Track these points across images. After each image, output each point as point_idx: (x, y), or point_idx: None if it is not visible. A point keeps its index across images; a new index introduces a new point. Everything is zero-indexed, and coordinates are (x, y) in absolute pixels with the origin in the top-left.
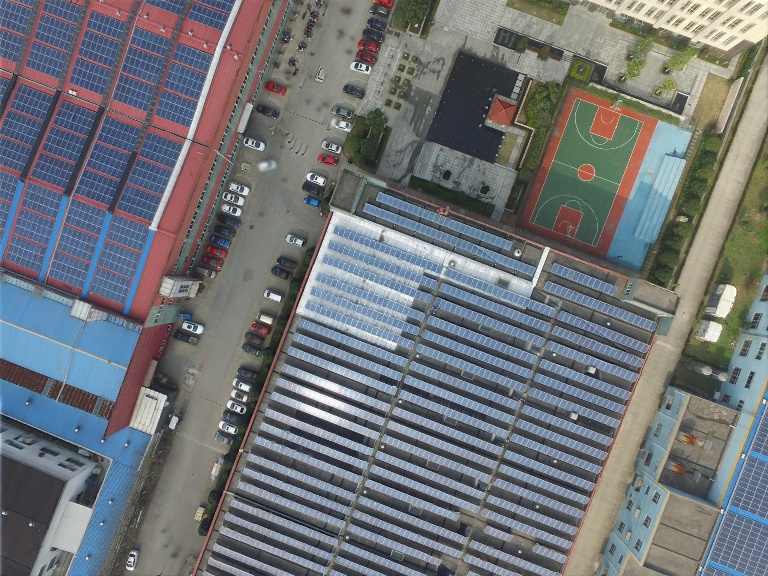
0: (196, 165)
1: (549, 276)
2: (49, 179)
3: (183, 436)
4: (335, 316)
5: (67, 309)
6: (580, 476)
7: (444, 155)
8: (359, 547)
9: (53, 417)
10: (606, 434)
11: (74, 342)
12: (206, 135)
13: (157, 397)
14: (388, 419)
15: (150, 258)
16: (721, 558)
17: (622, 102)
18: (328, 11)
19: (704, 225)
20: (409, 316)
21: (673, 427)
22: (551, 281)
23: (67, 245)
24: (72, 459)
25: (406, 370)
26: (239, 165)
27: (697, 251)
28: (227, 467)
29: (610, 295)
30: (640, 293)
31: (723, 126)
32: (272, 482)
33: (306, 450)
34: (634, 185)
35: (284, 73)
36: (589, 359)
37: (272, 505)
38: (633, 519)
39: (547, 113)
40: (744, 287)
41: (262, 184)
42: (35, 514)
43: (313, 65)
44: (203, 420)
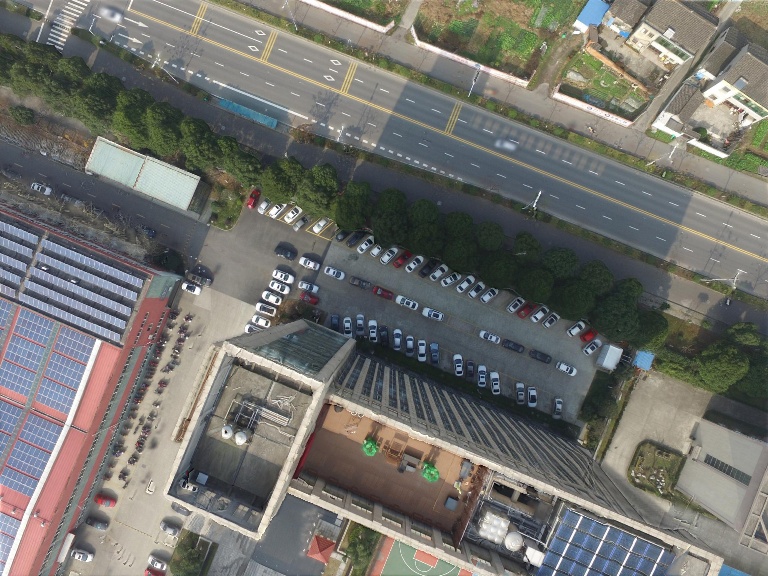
0: None
1: None
2: None
3: None
4: None
5: None
6: None
7: None
8: None
9: None
10: None
11: None
12: None
13: None
14: None
15: None
16: None
17: None
18: (161, 424)
19: None
20: None
21: None
22: None
23: None
24: None
25: None
26: (67, 574)
27: None
28: None
29: None
30: None
31: None
32: None
33: None
34: None
35: (115, 484)
36: None
37: None
38: None
39: (358, 568)
40: None
41: None
42: None
43: (144, 477)
44: None
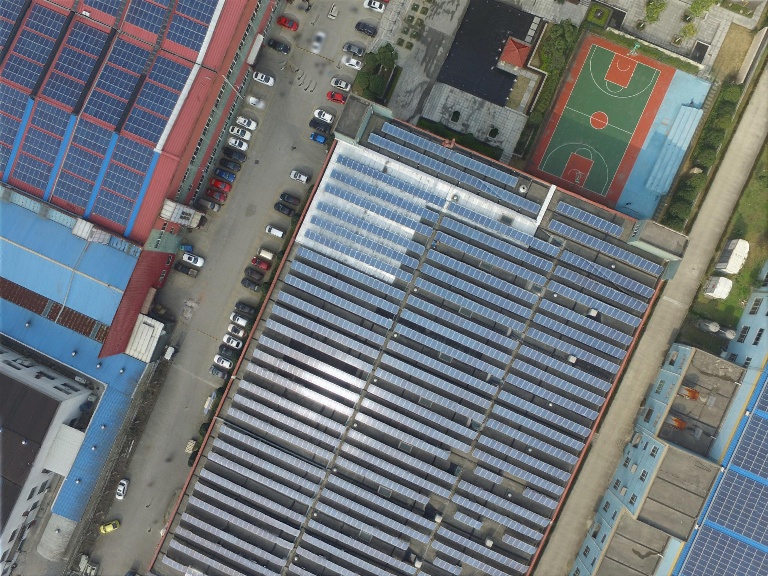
0: (203, 90)
1: (554, 215)
2: (58, 98)
3: (178, 368)
4: (334, 245)
5: (70, 232)
6: (576, 421)
7: (454, 97)
8: (346, 480)
9: (51, 340)
10: (605, 379)
11: (75, 264)
12: (215, 60)
13: (154, 325)
14: (382, 353)
15: (153, 181)
16: (719, 517)
17: (639, 48)
18: None
19: (719, 179)
20: (409, 249)
21: (676, 382)
22: (556, 220)
23: (73, 164)
24: (68, 384)
25: (403, 304)
26: (247, 99)
27: (710, 206)
28: (220, 400)
29: (616, 237)
30: (647, 234)
31: (744, 76)
32: (262, 410)
33: (298, 380)
34: (648, 135)
35: (297, 9)
36: (591, 301)
37: (261, 433)
38: (629, 475)
39: (561, 53)
40: (758, 244)
41: (269, 119)
42: (28, 432)
43: (326, 2)
44: (199, 353)
